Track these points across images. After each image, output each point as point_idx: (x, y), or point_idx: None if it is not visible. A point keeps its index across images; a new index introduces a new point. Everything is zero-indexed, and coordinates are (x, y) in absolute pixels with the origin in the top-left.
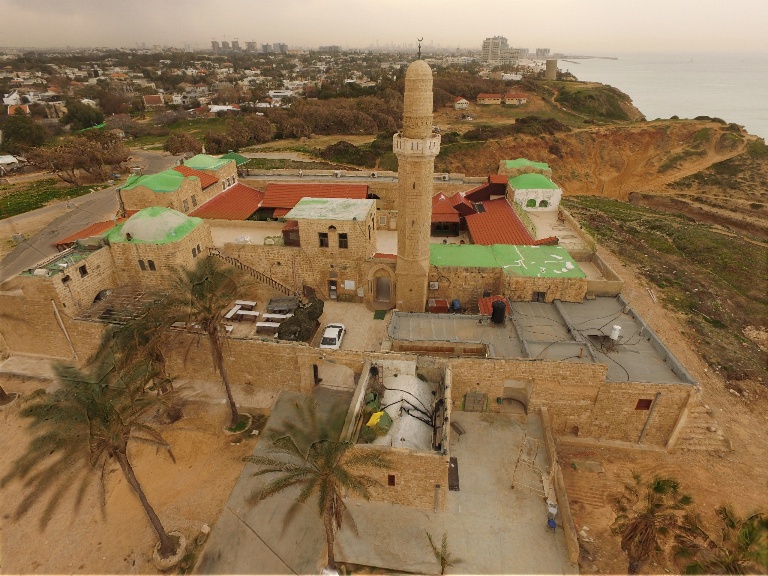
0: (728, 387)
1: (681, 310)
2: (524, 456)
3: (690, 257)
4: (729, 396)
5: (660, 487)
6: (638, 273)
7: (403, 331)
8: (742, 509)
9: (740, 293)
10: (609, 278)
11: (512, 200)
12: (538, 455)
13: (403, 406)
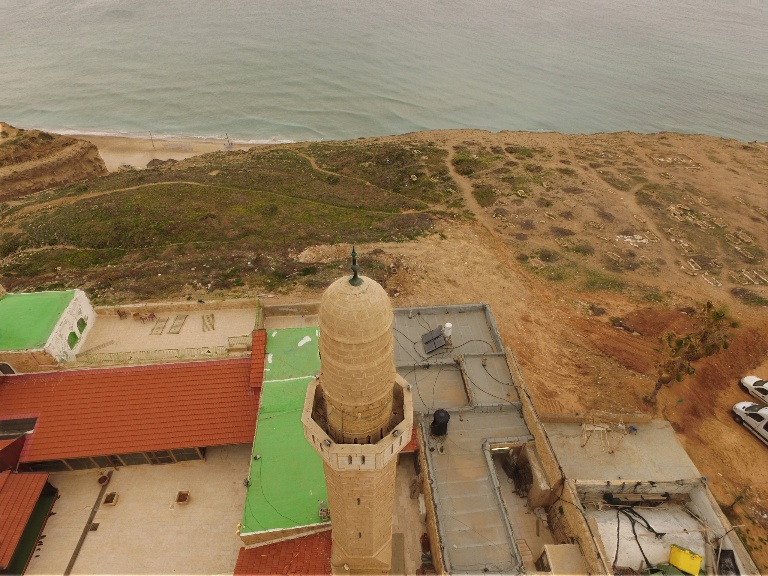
0: (393, 296)
1: (288, 285)
2: (572, 441)
3: (129, 246)
4: (400, 299)
5: (681, 341)
6: (210, 292)
7: (489, 556)
8: (512, 331)
9: (225, 241)
10: (317, 311)
11: (55, 363)
12: (565, 430)
13: (648, 534)
